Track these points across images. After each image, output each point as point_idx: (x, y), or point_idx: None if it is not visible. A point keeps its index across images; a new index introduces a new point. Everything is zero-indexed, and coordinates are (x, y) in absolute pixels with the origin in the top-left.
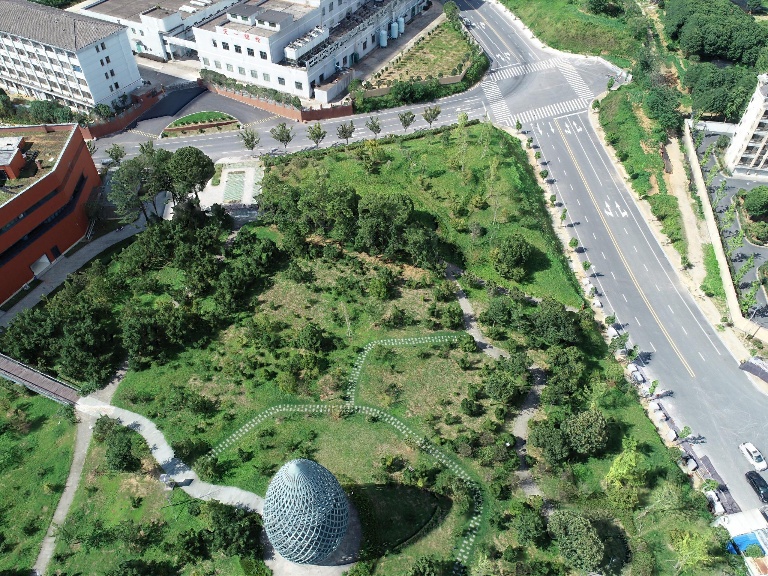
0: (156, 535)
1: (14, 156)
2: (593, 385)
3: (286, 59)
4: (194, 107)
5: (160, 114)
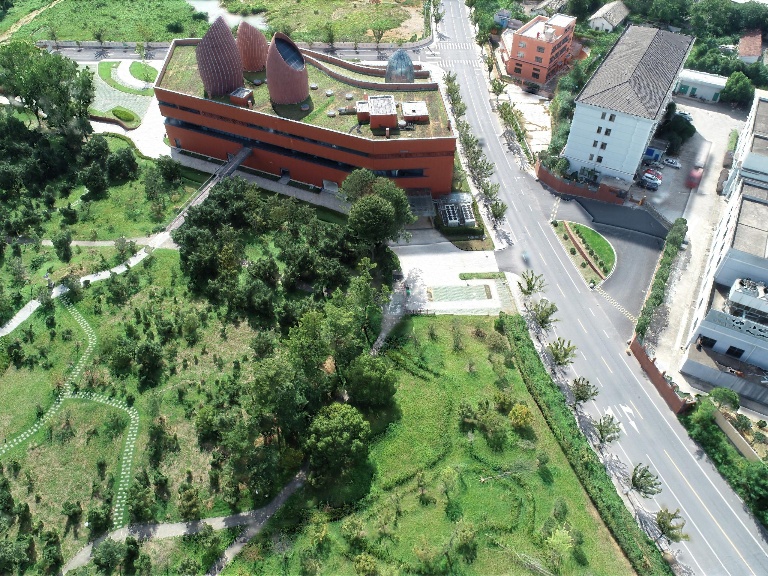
0: (19, 284)
1: (383, 115)
2: None
3: None
4: (617, 235)
5: (594, 211)
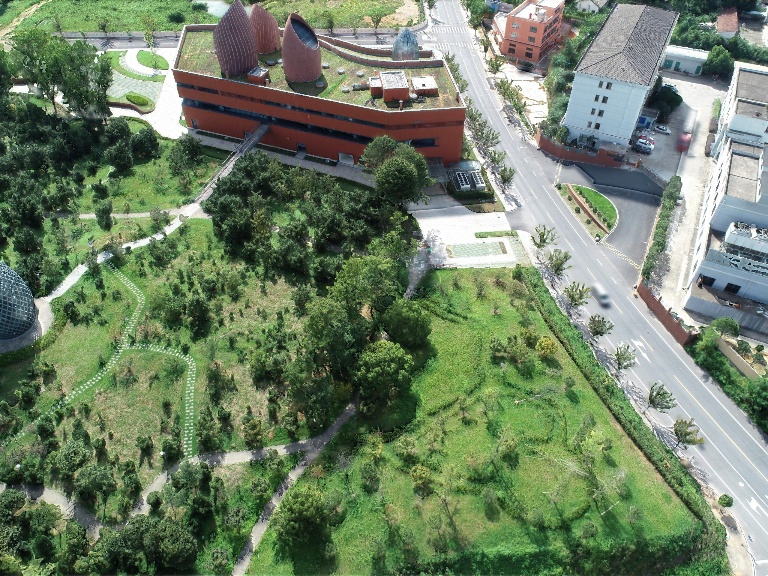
0: (63, 253)
1: (396, 88)
2: (41, 569)
3: (725, 234)
4: (618, 194)
5: (595, 175)
